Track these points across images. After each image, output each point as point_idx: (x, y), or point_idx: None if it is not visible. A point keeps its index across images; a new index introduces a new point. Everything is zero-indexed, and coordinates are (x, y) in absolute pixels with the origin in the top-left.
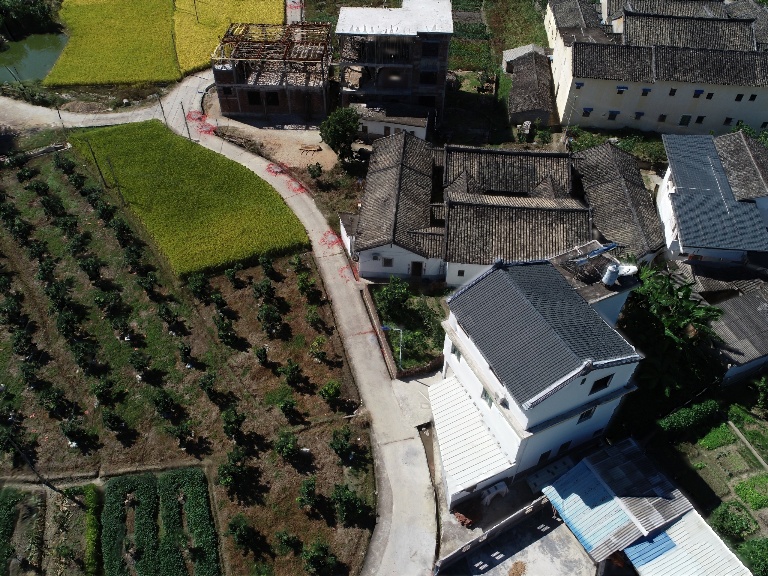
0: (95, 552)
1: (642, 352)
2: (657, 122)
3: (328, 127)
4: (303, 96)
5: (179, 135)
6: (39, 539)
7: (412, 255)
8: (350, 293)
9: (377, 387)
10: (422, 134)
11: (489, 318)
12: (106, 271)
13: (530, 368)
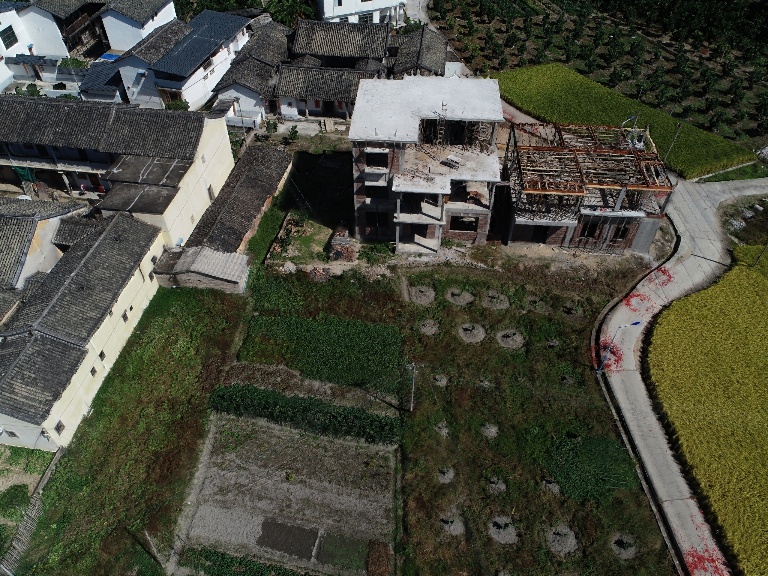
0: None
1: None
2: None
3: None
4: None
5: None
6: None
7: None
8: None
9: None
10: None
11: None
12: (608, 73)
13: None
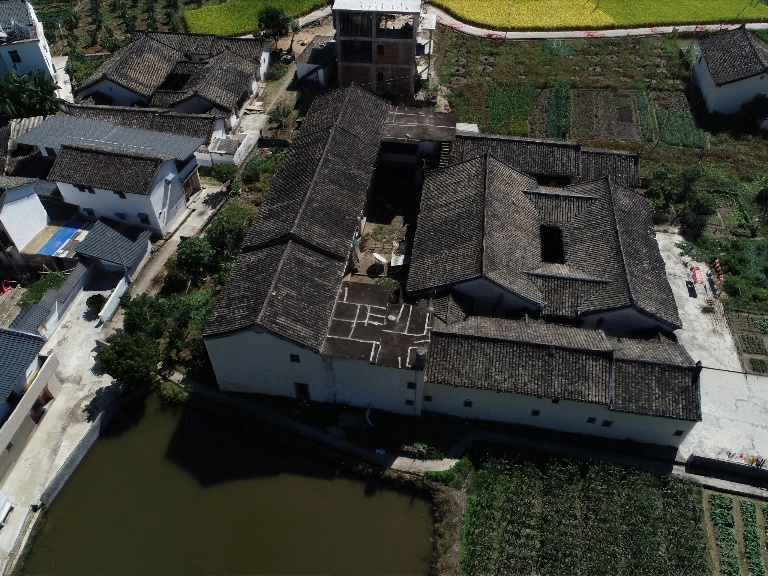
0: (40, 13)
1: None
2: None
3: None
4: None
5: (324, 1)
6: (56, 7)
7: None
8: None
9: None
10: None
11: None
12: None
13: None
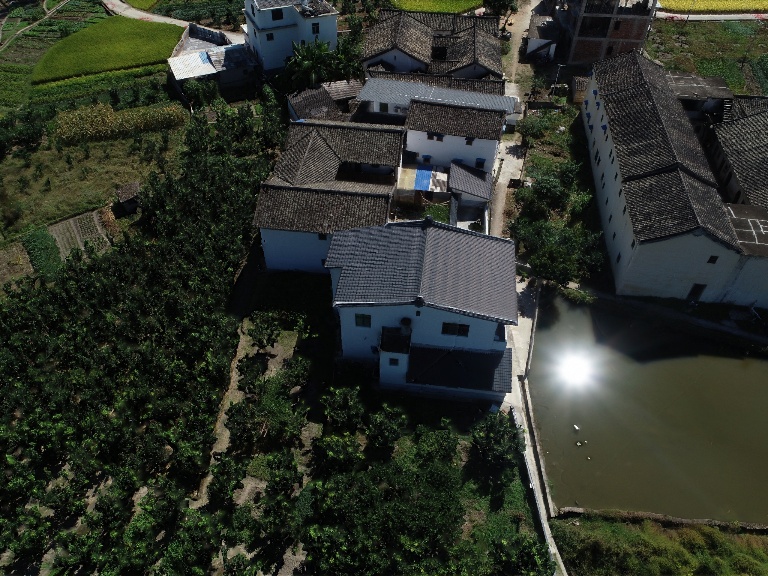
0: None
1: None
2: None
3: None
4: None
5: None
6: None
7: None
8: None
9: None
10: None
11: None
12: None
13: None
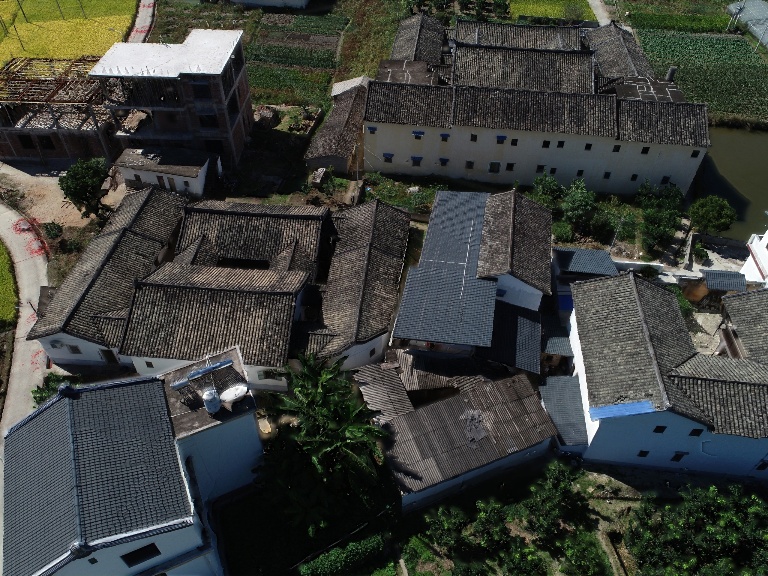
0: None
1: (289, 480)
2: (465, 169)
3: (61, 183)
4: (78, 140)
5: None
6: None
7: (93, 344)
8: (31, 385)
9: (2, 512)
10: (196, 184)
11: (29, 464)
12: None
13: (33, 542)
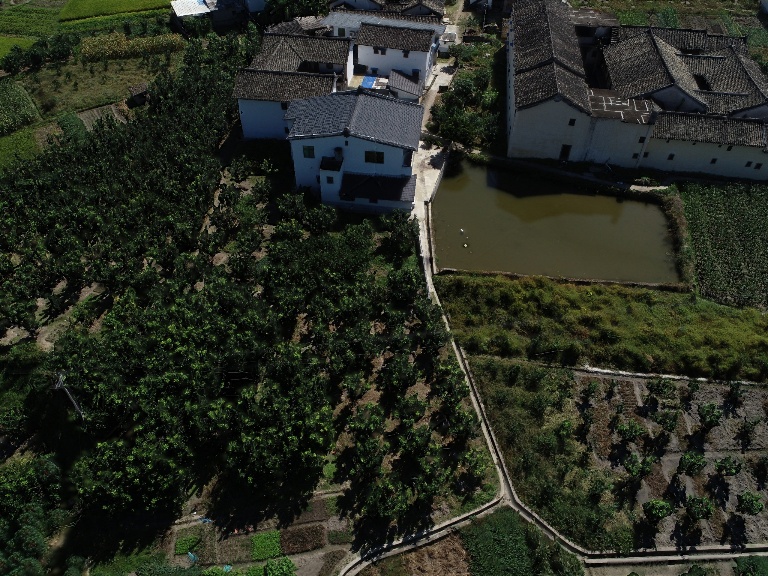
0: None
1: None
2: None
3: None
4: None
5: None
6: None
7: None
8: None
9: None
10: None
11: None
12: None
13: None
